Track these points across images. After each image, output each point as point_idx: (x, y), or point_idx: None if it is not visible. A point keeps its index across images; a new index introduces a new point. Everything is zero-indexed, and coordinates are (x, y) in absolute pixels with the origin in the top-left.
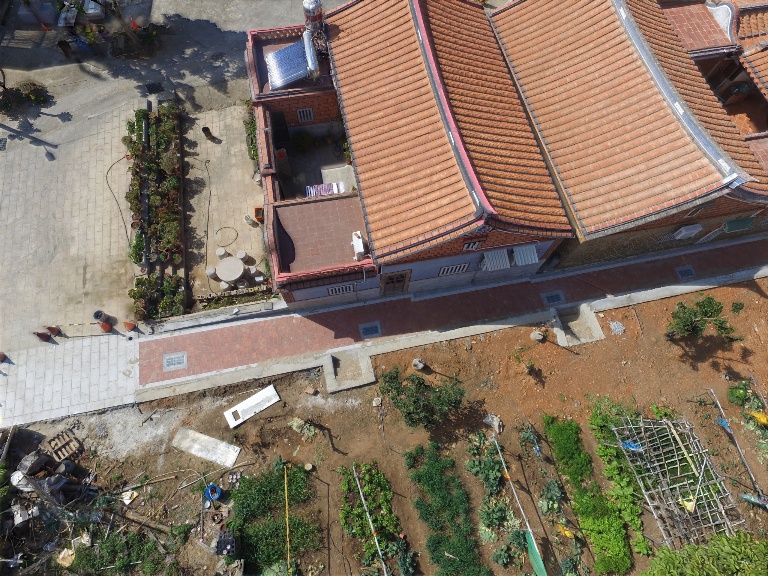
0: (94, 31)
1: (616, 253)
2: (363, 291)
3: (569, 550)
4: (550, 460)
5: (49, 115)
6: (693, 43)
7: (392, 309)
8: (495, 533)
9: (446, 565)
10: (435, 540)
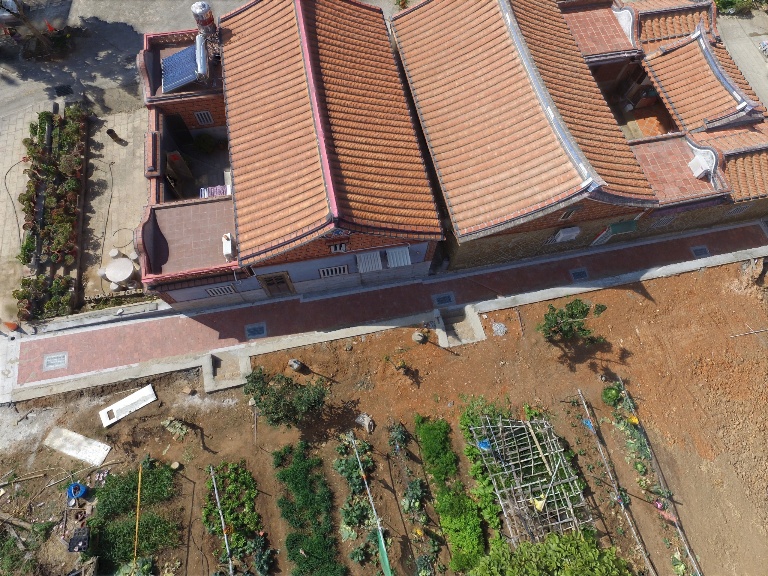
0: (9, 34)
1: (506, 255)
2: (246, 292)
3: (427, 548)
4: (418, 459)
5: None
6: (595, 47)
7: (280, 310)
8: (355, 531)
9: (301, 562)
10: (293, 538)
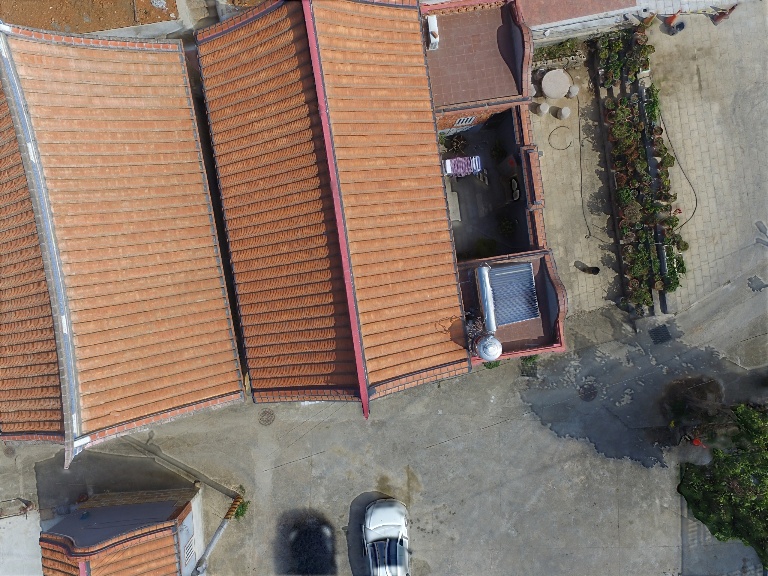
0: None
1: None
2: None
3: None
4: None
5: None
6: None
7: None
8: None
9: None
10: None
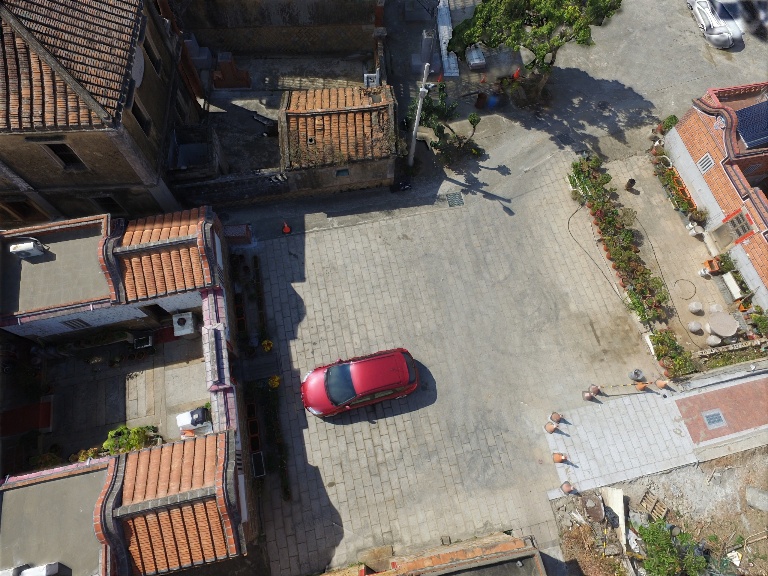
0: None
1: None
2: None
3: None
4: None
5: (488, 168)
6: None
7: None
8: None
9: None
10: None
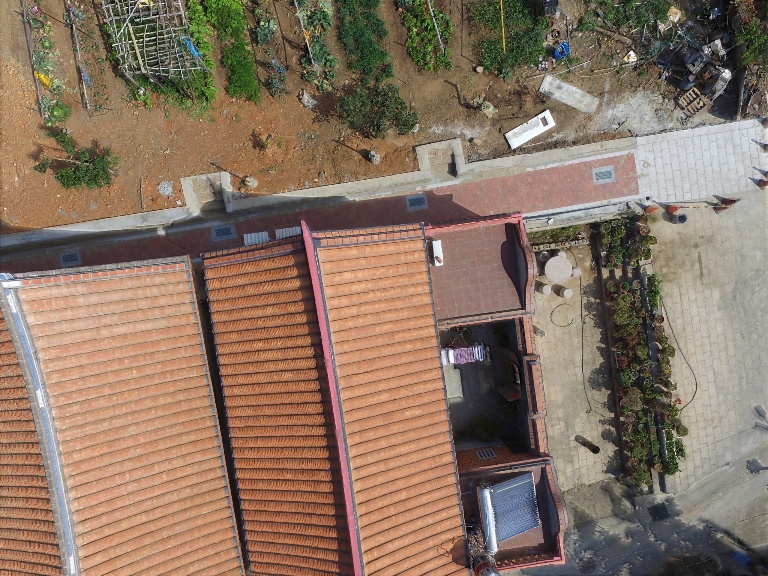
0: None
1: None
2: None
3: None
4: (259, 64)
5: None
6: None
7: None
8: (319, 7)
9: None
10: (373, 2)
